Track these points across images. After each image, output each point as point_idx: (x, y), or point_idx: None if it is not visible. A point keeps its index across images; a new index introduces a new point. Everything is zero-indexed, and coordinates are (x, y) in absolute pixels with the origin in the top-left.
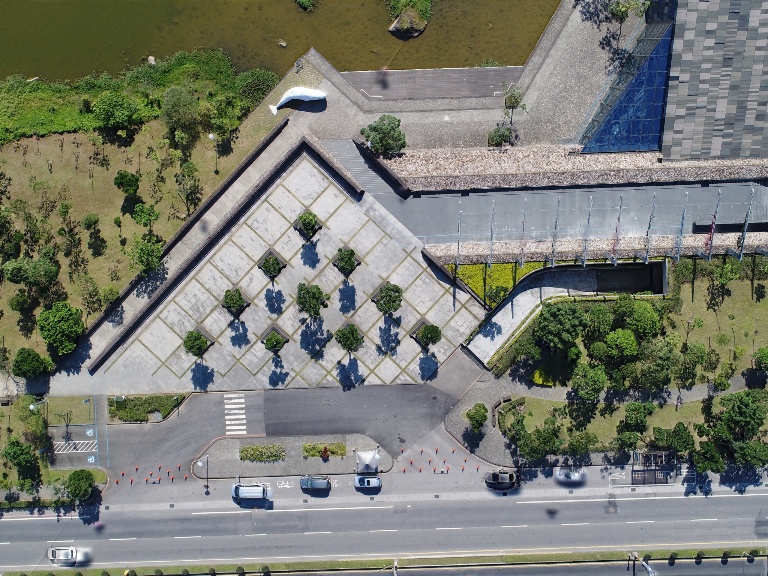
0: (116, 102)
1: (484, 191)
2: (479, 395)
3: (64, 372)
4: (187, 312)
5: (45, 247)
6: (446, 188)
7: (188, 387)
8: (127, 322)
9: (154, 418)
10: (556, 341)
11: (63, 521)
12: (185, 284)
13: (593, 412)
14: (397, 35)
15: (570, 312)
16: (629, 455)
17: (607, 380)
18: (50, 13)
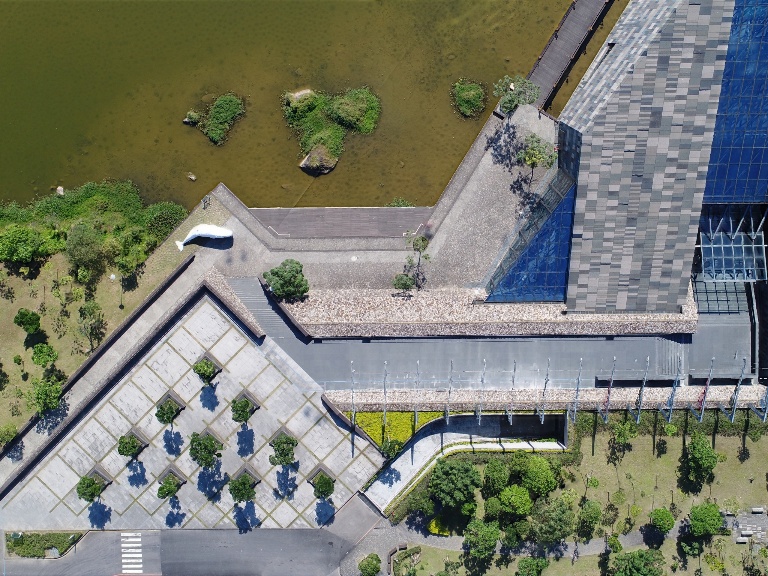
0: (20, 238)
1: (386, 338)
2: (375, 542)
3: None
4: (86, 451)
5: None
6: (347, 335)
7: (85, 525)
8: (26, 459)
9: (51, 554)
10: (447, 500)
11: None
12: (84, 423)
13: (489, 563)
14: (307, 171)
15: (463, 470)
16: None
17: (504, 531)
18: None
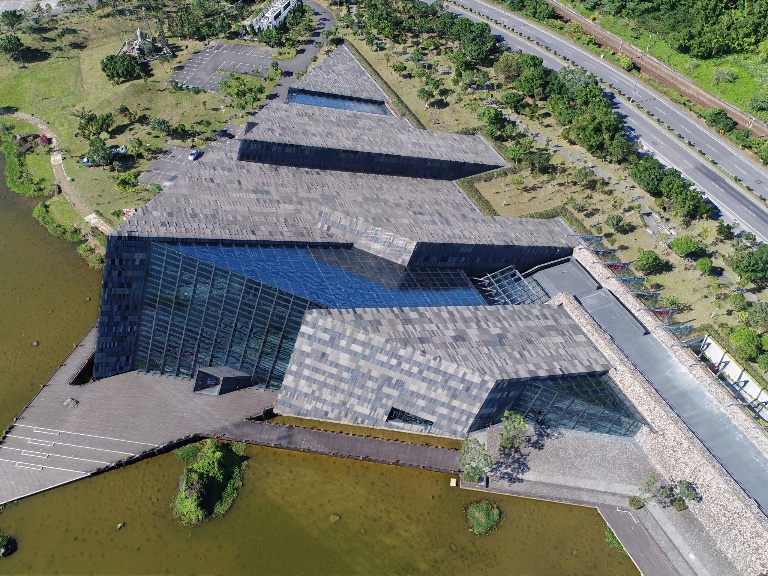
0: None
1: None
2: None
3: None
4: None
5: None
6: (767, 520)
7: None
8: None
9: None
10: None
11: None
12: None
13: None
14: None
15: None
16: None
17: None
18: None
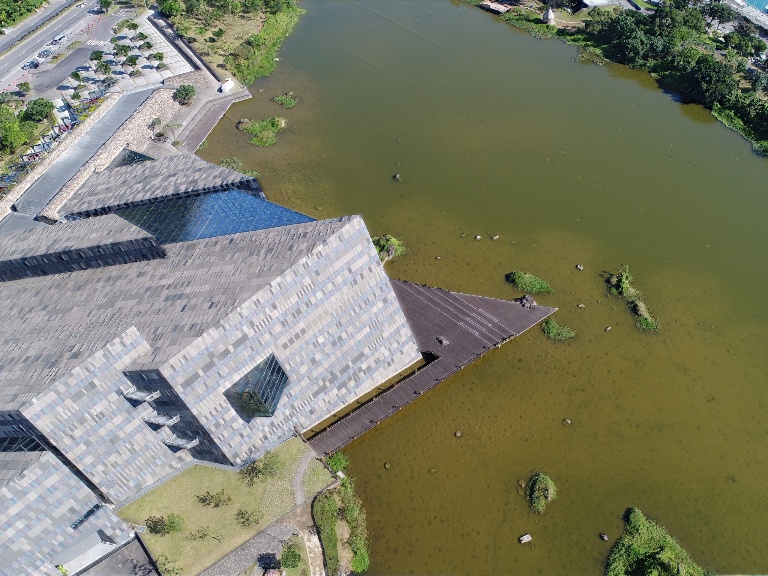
0: (257, 38)
1: None
2: None
3: (154, 13)
4: None
5: None
6: None
7: None
8: None
9: None
10: None
11: (96, 7)
12: None
13: None
14: None
15: None
16: None
17: None
18: None
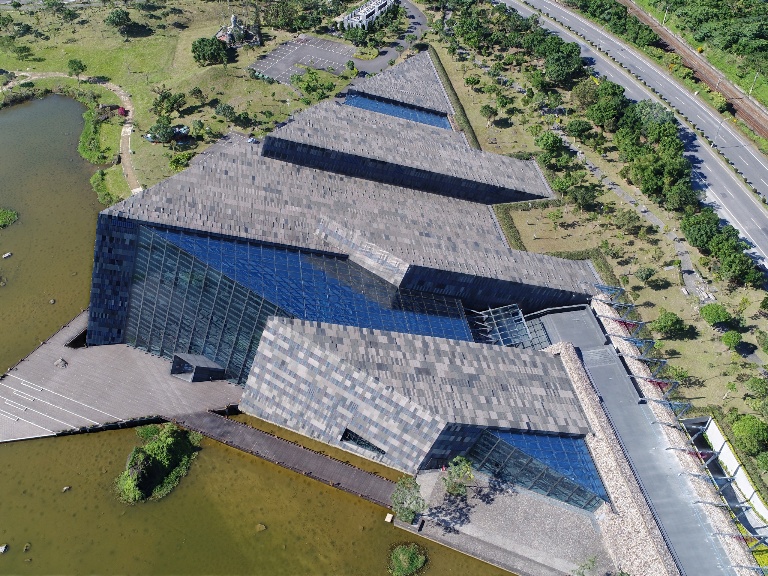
0: None
1: None
2: None
3: None
4: None
5: None
6: None
7: None
8: None
9: None
10: None
11: None
12: None
13: None
14: None
15: None
16: None
17: None
18: None
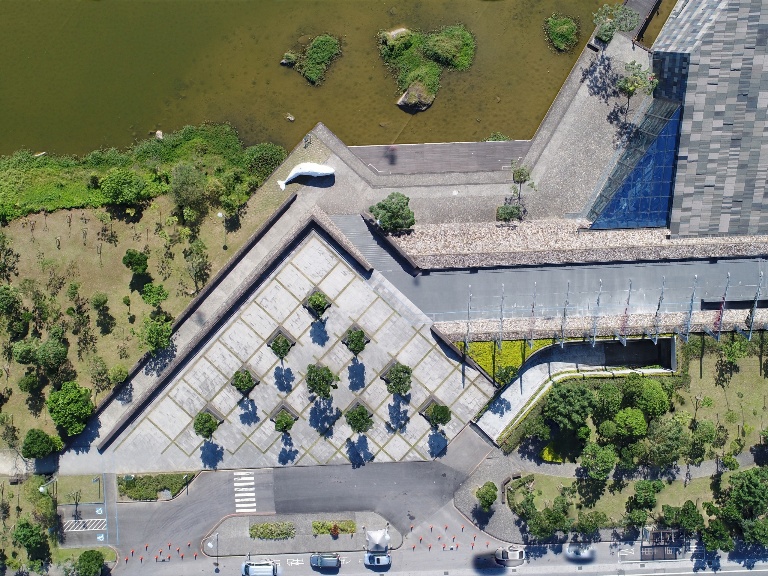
0: (124, 180)
1: (493, 268)
2: (488, 472)
3: (73, 451)
4: (196, 390)
5: (54, 327)
6: (455, 266)
7: (197, 465)
8: (136, 401)
9: (163, 496)
10: (566, 422)
11: None
12: (194, 362)
13: (602, 488)
14: (405, 109)
15: (580, 393)
16: (638, 531)
17: (616, 456)
18: (57, 87)
